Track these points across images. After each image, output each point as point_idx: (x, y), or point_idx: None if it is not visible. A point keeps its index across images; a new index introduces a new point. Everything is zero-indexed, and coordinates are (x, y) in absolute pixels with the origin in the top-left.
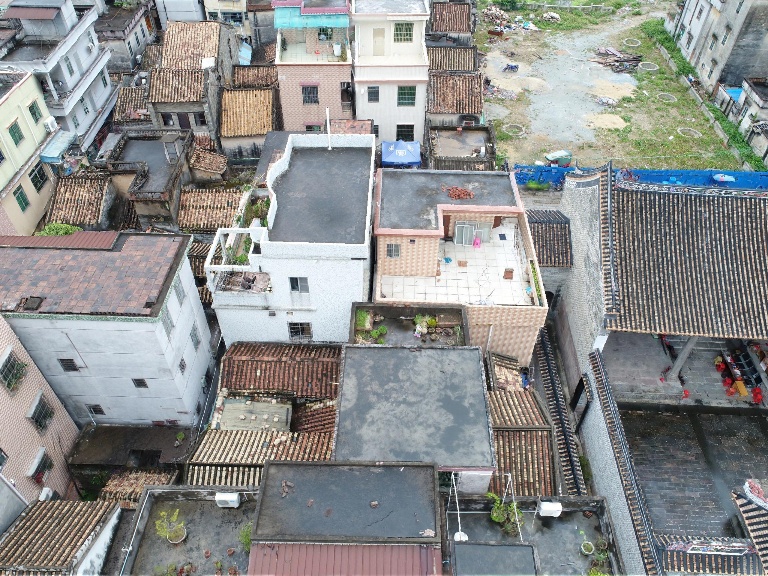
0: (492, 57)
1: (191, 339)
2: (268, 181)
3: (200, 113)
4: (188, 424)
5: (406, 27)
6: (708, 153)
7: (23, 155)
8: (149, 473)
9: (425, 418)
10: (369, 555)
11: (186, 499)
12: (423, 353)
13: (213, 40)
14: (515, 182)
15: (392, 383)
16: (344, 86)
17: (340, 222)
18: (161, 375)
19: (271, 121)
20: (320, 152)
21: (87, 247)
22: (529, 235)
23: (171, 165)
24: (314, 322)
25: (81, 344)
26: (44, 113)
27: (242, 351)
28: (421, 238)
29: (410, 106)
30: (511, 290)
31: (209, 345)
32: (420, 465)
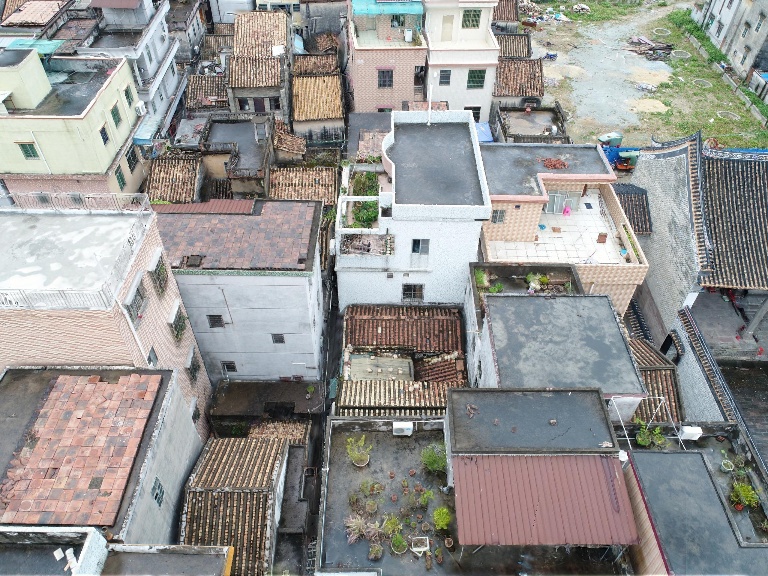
0: None
1: (317, 300)
2: (384, 152)
3: (275, 98)
4: (314, 379)
5: (474, 14)
6: (749, 134)
7: (121, 137)
8: (285, 423)
9: (573, 354)
10: (557, 464)
11: (361, 430)
12: (558, 300)
13: (281, 29)
14: None
15: (536, 326)
16: (418, 70)
17: (456, 188)
18: (300, 330)
19: (341, 105)
20: (420, 127)
21: (228, 212)
22: (618, 202)
23: (259, 146)
24: (427, 283)
25: (233, 300)
26: (135, 97)
27: (360, 311)
28: (526, 204)
29: (479, 89)
30: (606, 252)
31: (322, 308)
32: (586, 390)
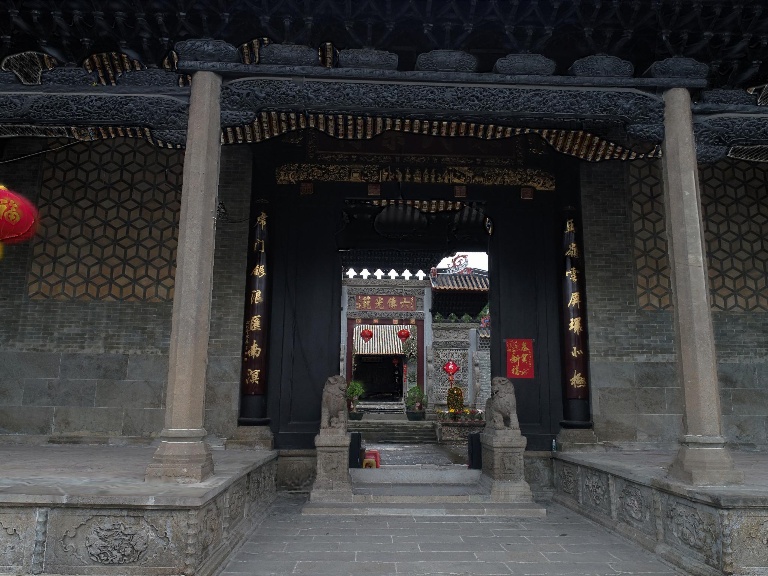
0: None
1: None
2: None
3: None
4: None
5: None
6: None
7: None
8: None
9: None
10: None
11: None
12: None
13: None
14: None
15: None
16: None
17: None
18: None
19: None
20: None
21: None
22: None
23: None
24: None
25: None
26: None
27: None
28: None
29: None
30: None
31: None
32: None
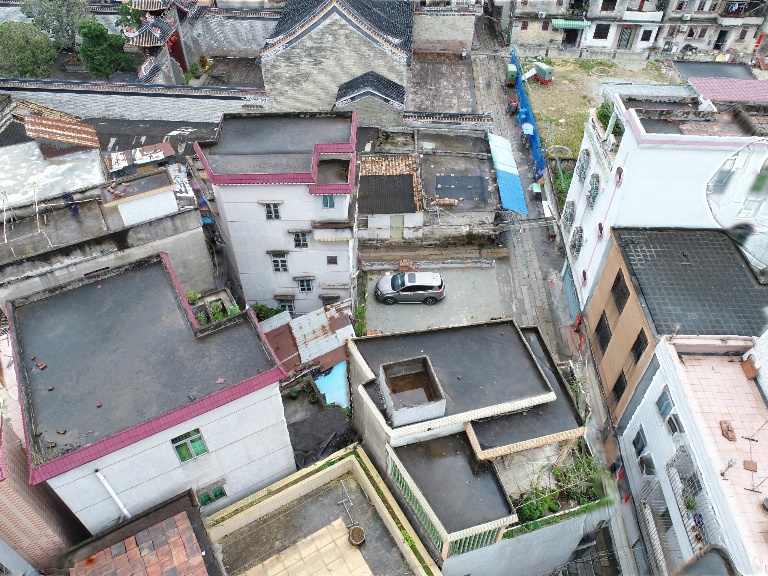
0: (761, 72)
1: None
2: None
3: None
4: None
5: None
6: None
7: None
8: None
9: None
10: None
11: None
12: None
13: None
14: None
15: None
16: None
17: None
18: None
19: None
20: None
21: None
22: None
23: None
24: None
25: None
26: None
27: None
28: None
29: None
30: None
31: None
32: None
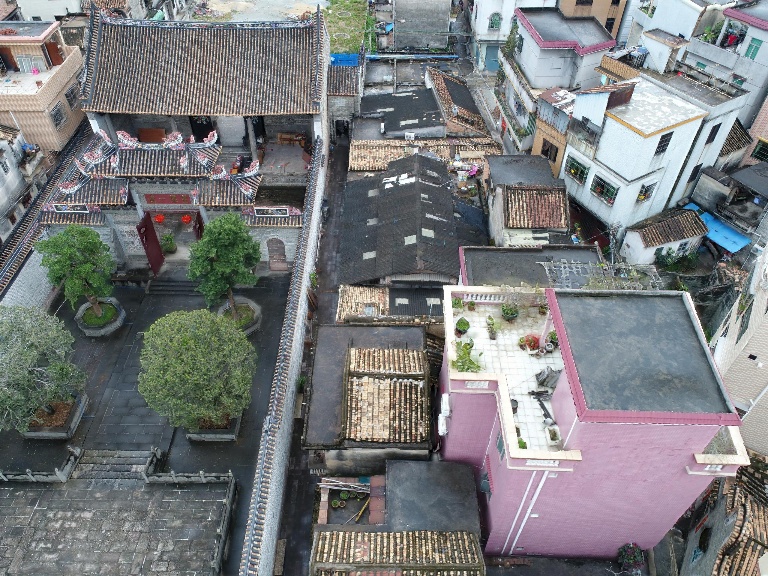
0: None
1: None
2: None
3: None
4: None
5: None
6: (344, 48)
7: None
8: None
9: None
10: None
11: None
12: None
13: None
14: (54, 26)
15: None
16: None
17: None
18: None
19: None
20: None
21: None
22: None
23: None
24: None
25: None
26: None
27: None
28: None
29: None
30: None
31: None
32: None
